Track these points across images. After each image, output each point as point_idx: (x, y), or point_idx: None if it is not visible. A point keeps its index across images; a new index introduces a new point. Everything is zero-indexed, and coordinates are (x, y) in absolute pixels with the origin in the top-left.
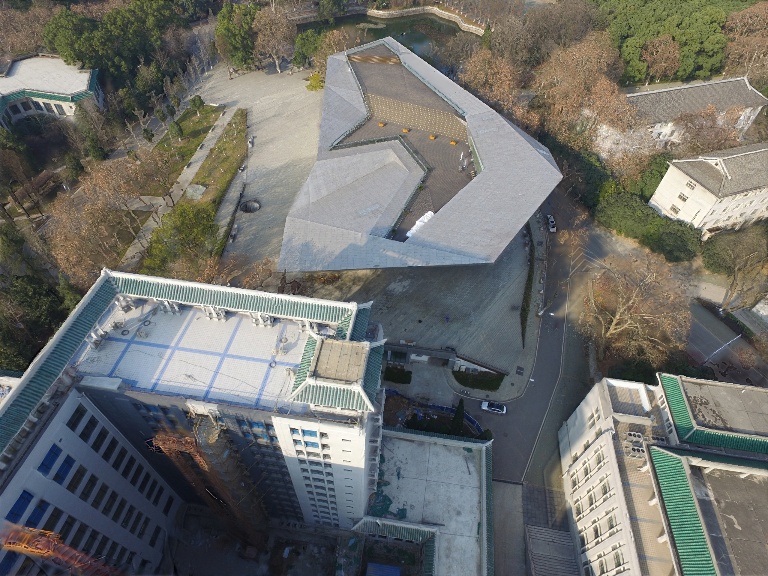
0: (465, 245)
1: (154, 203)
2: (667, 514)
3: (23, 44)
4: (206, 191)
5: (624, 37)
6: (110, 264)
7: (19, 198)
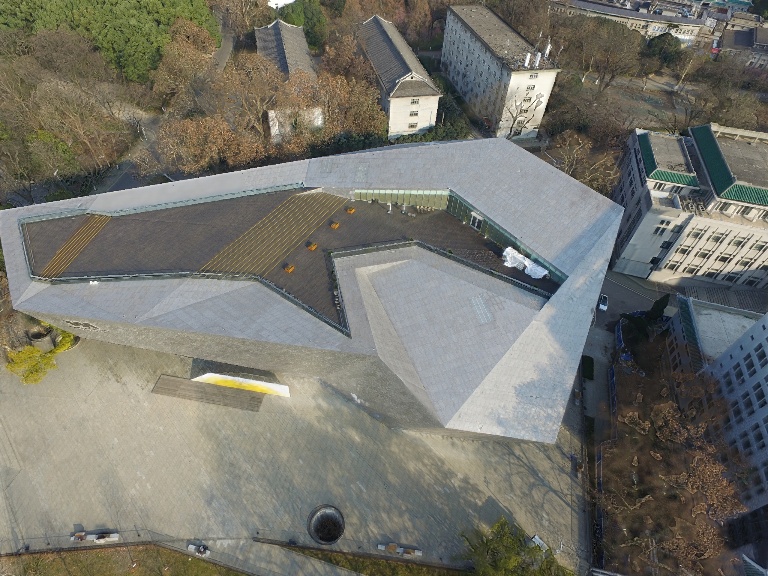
0: (592, 224)
1: None
2: (762, 205)
3: None
4: None
5: (127, 42)
6: None
7: None
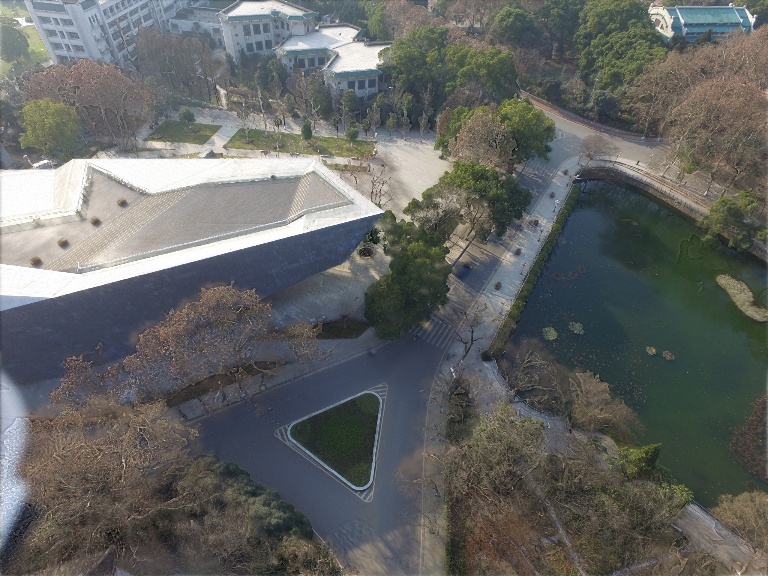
0: None
1: (215, 144)
2: None
3: (403, 35)
4: None
5: None
6: (150, 138)
7: (229, 90)
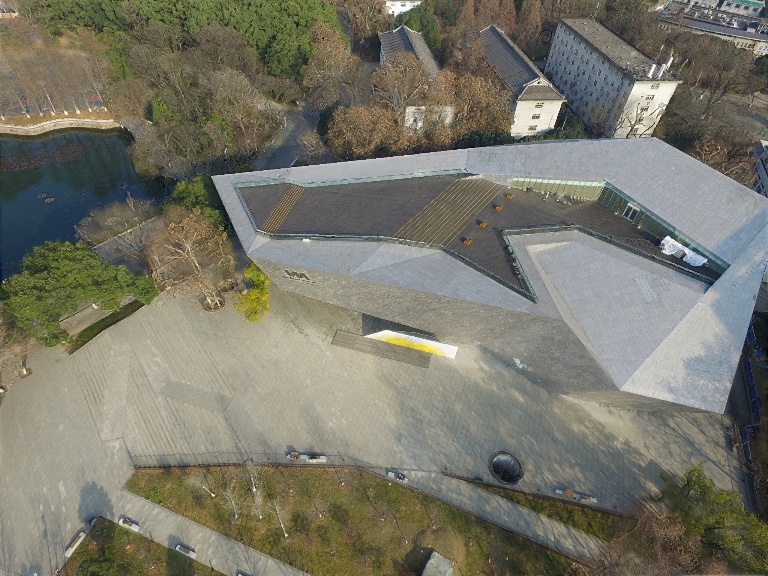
0: (751, 220)
1: None
2: None
3: None
4: (442, 552)
5: (268, 41)
6: None
7: None
